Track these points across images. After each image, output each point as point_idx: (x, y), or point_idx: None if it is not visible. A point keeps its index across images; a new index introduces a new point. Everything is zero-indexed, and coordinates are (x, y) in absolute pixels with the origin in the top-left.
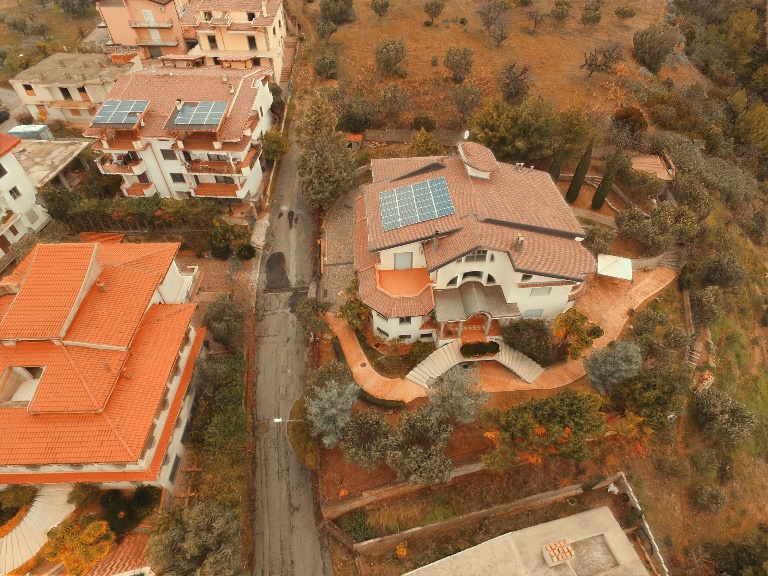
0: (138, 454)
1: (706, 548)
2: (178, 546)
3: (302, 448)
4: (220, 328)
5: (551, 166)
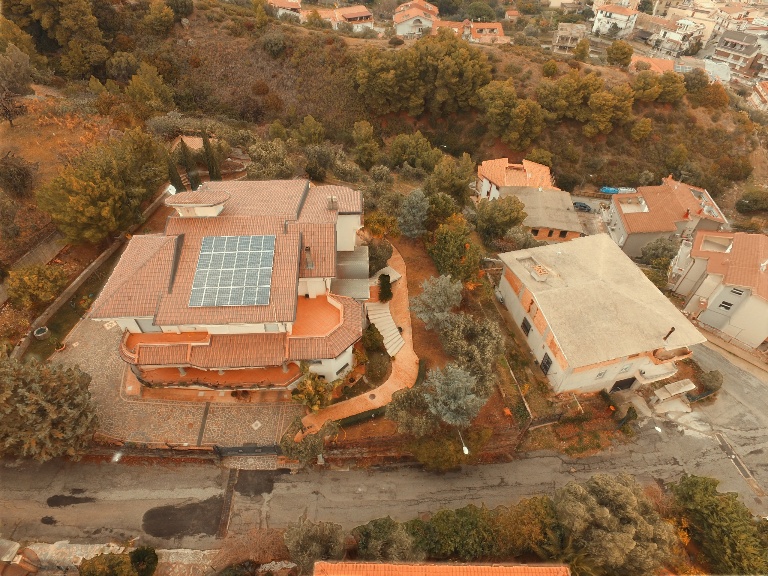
0: (557, 568)
1: (487, 244)
2: (607, 525)
3: (474, 445)
4: (344, 537)
5: (175, 186)
